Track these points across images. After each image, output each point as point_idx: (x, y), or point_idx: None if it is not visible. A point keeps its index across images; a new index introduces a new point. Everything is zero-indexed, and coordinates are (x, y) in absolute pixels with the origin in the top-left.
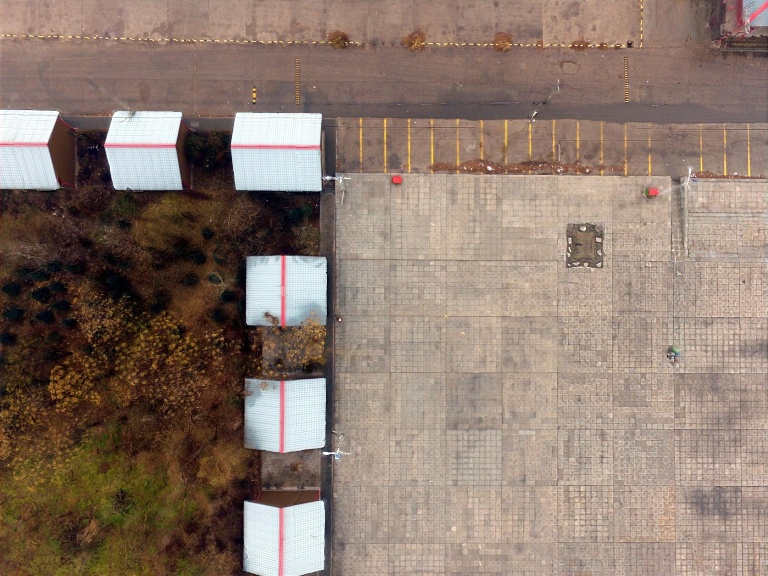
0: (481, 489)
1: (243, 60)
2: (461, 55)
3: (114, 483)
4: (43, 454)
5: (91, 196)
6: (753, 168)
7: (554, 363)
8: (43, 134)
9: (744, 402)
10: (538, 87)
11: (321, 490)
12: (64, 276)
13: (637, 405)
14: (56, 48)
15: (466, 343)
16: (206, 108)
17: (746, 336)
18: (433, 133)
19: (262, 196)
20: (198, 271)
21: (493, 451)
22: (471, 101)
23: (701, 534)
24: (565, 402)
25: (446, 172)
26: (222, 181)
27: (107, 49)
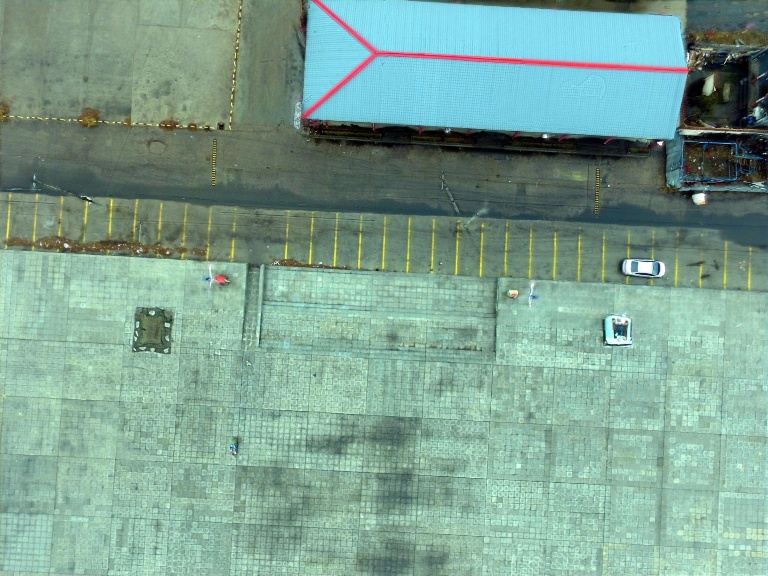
0: (27, 575)
1: None
2: (45, 129)
3: None
4: None
5: None
6: (339, 258)
7: (113, 449)
8: None
9: (307, 499)
10: (122, 165)
11: None
12: None
13: (196, 496)
14: None
15: (23, 424)
16: None
17: (313, 431)
18: (10, 207)
19: None
20: None
21: (43, 537)
22: (53, 176)
23: None
24: (121, 490)
25: (20, 247)
26: None
27: None
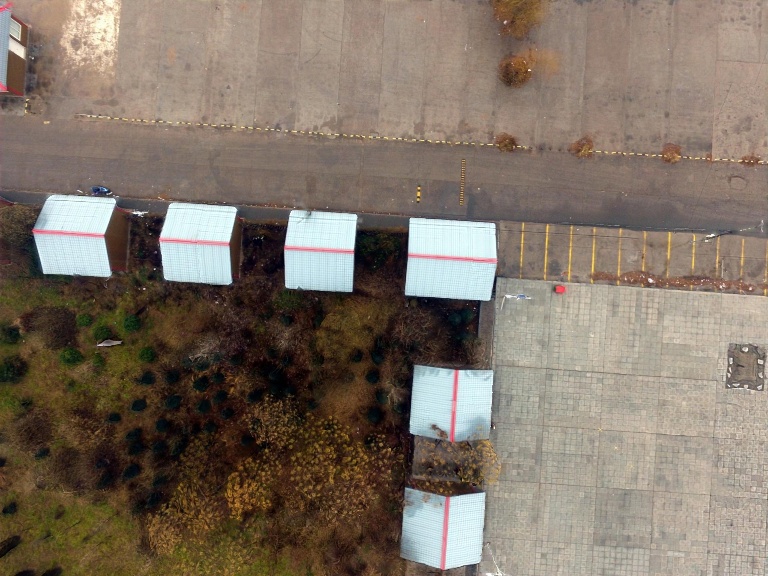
0: None
1: (410, 158)
2: (628, 164)
3: (258, 575)
4: (215, 560)
5: (253, 286)
6: None
7: (708, 485)
8: (224, 232)
9: None
10: (704, 201)
11: None
12: (222, 365)
13: None
14: (228, 137)
15: (619, 458)
16: (370, 204)
17: None
18: (595, 241)
19: None
20: (353, 367)
21: (640, 571)
22: (635, 211)
23: None
24: (717, 526)
25: (606, 282)
26: (383, 279)
27: (277, 140)
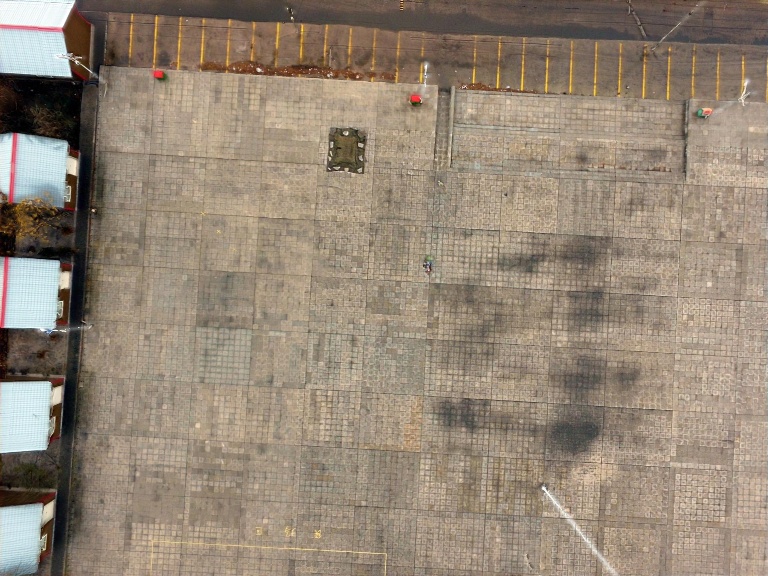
0: (228, 388)
1: None
2: None
3: None
4: None
5: None
6: (526, 82)
7: (309, 266)
8: None
9: (499, 316)
10: None
11: (66, 378)
12: None
13: (390, 313)
14: None
15: (221, 241)
16: None
17: (505, 249)
18: (204, 32)
19: (26, 85)
20: None
21: (242, 350)
22: (244, 2)
23: (447, 445)
24: (317, 306)
25: (214, 71)
26: None
27: None
